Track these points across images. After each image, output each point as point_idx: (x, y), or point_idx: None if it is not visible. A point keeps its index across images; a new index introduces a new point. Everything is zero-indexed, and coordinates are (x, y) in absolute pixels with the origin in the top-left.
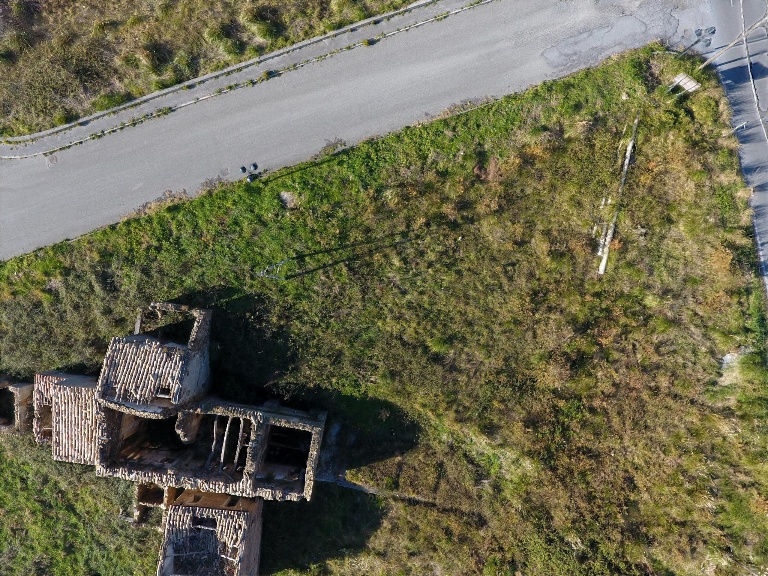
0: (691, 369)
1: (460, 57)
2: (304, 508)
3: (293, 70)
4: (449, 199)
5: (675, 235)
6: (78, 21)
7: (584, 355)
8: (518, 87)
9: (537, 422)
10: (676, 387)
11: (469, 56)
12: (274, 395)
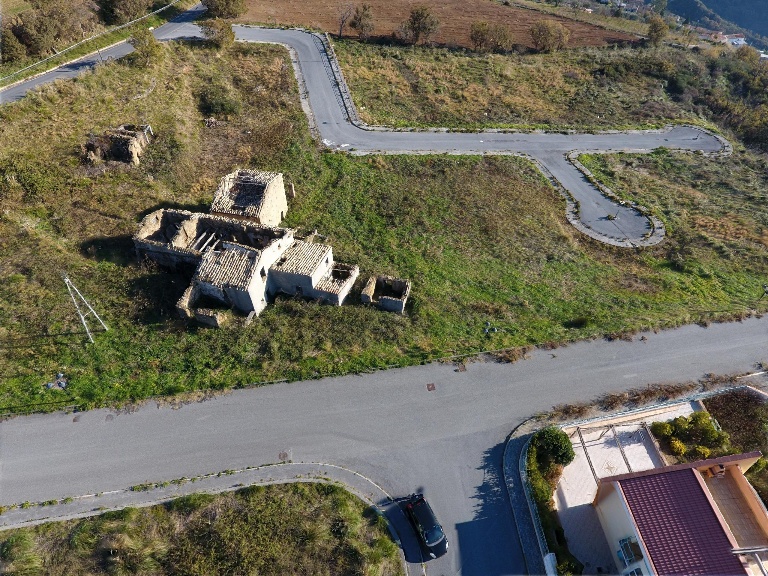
0: None
1: None
2: None
3: None
4: None
5: None
6: None
7: None
8: None
9: None
10: None
11: None
12: None
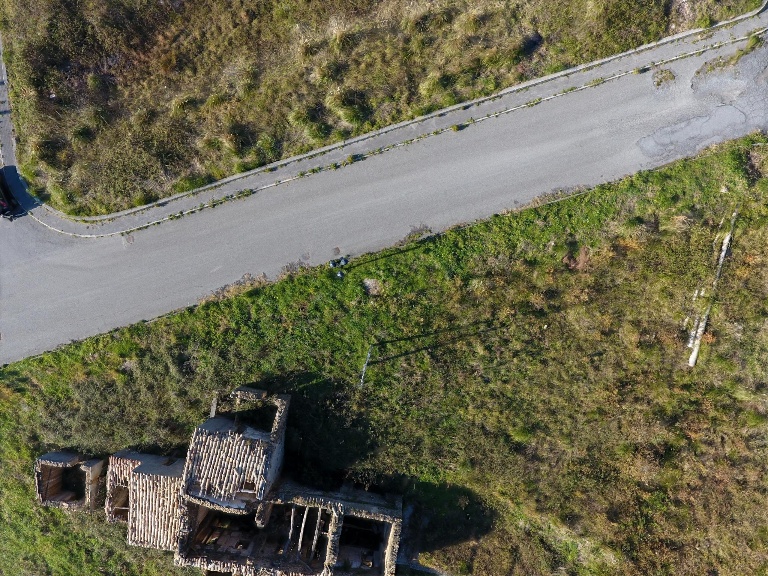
0: None
1: (551, 145)
2: None
3: (378, 154)
4: (536, 288)
5: None
6: (154, 96)
7: (671, 448)
8: (611, 177)
9: (620, 513)
10: (765, 482)
11: (561, 144)
12: (348, 477)
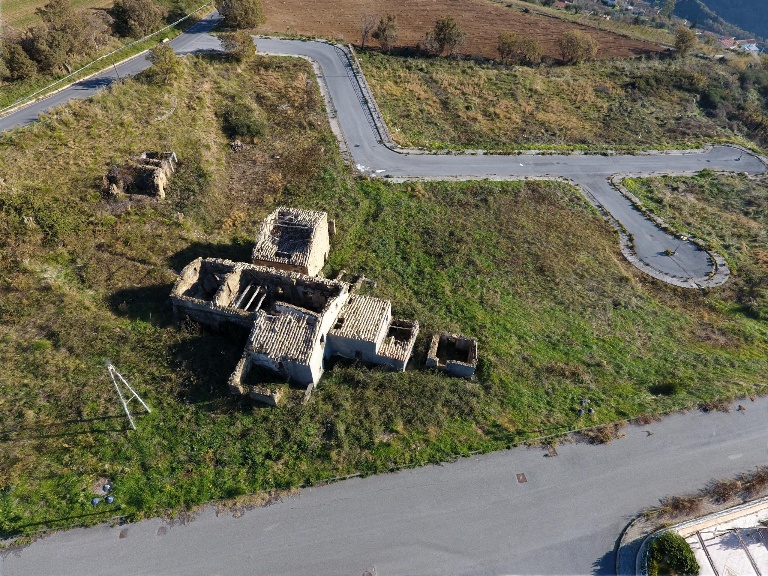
0: None
1: None
2: None
3: None
4: None
5: None
6: None
7: None
8: None
9: (4, 289)
10: None
11: None
12: (216, 334)
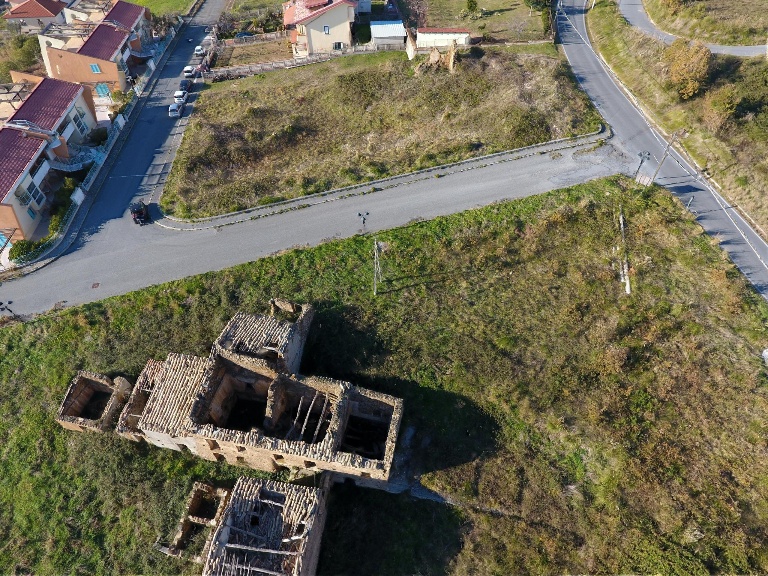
0: (738, 364)
1: (496, 181)
2: (369, 538)
3: (390, 188)
4: None
5: (676, 269)
6: (256, 176)
7: (635, 351)
8: (536, 193)
9: (610, 413)
10: (732, 380)
11: (502, 181)
12: None
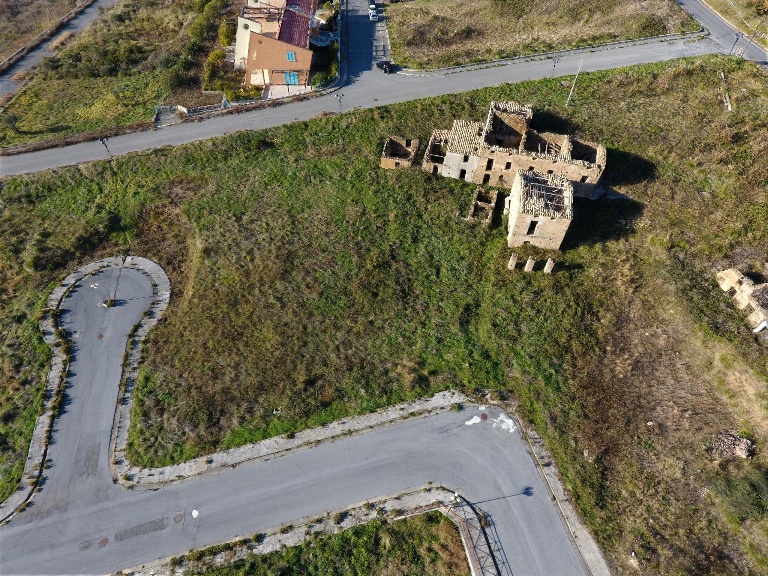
0: None
1: (632, 55)
2: None
3: (558, 57)
4: None
5: None
6: None
7: (738, 134)
8: None
9: None
10: None
11: None
12: None
